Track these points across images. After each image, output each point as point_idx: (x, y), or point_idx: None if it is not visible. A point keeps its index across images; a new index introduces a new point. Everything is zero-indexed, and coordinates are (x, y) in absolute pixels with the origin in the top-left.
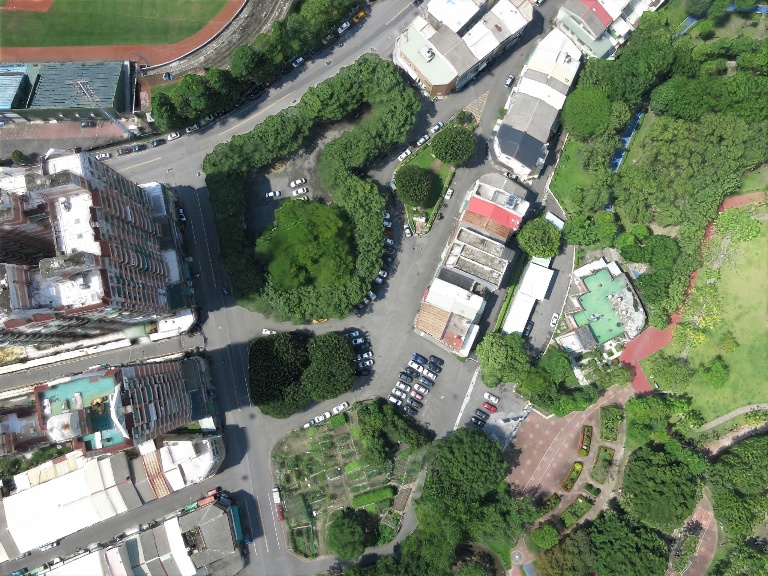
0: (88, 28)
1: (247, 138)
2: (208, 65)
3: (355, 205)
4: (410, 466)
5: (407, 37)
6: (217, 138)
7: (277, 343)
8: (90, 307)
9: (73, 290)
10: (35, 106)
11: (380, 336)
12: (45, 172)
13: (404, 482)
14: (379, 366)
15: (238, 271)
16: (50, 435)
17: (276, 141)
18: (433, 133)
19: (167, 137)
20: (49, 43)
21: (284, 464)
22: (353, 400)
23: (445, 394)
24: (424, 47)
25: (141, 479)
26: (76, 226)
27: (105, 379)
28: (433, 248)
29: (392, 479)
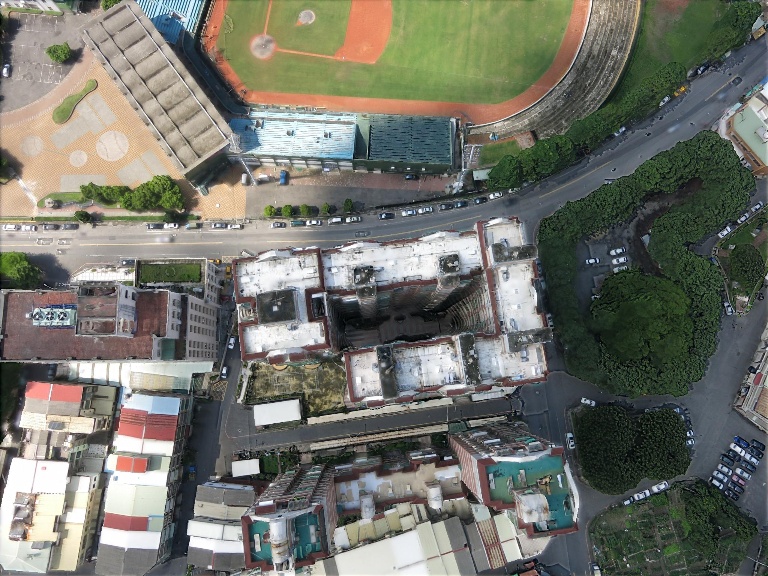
0: (414, 83)
1: (585, 205)
2: (533, 128)
3: (694, 281)
4: (734, 555)
5: (742, 117)
6: (537, 200)
7: (618, 417)
8: (532, 381)
9: (511, 361)
10: (374, 157)
11: (700, 415)
12: (485, 240)
13: (725, 571)
14: (699, 446)
15: (576, 339)
16: (527, 517)
17: (612, 210)
18: (753, 212)
19: (489, 196)
20: (375, 95)
21: (603, 541)
22: (672, 479)
23: (767, 481)
24: (761, 128)
25: (477, 547)
26: (514, 296)
27: (550, 457)
28: (753, 328)
29: (714, 567)
